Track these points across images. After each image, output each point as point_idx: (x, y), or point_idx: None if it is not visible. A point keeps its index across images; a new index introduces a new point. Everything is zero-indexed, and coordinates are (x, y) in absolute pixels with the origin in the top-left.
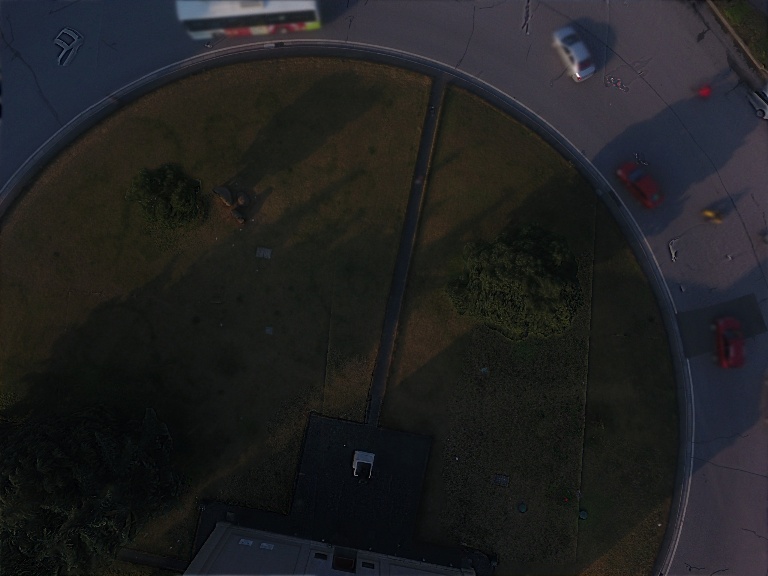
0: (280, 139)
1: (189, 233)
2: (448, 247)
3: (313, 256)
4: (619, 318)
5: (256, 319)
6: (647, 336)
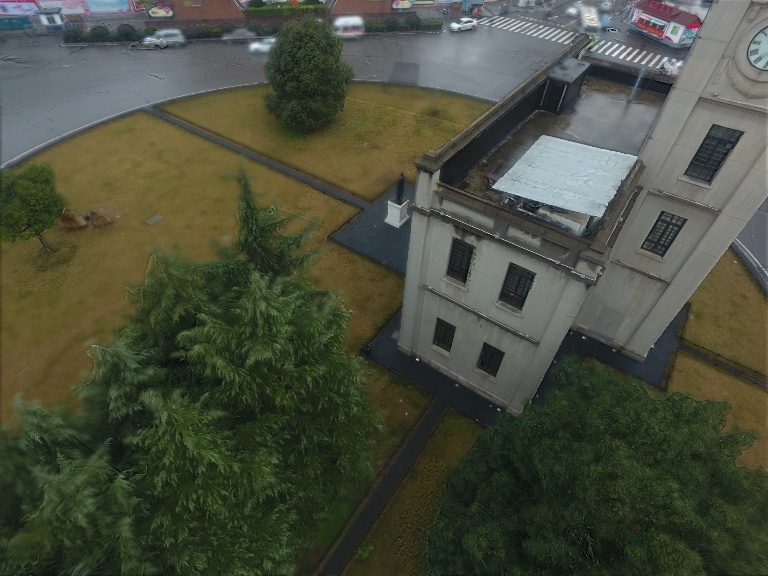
0: (77, 181)
1: (71, 261)
2: (261, 134)
3: (192, 192)
4: (373, 94)
5: (206, 242)
6: (393, 90)
